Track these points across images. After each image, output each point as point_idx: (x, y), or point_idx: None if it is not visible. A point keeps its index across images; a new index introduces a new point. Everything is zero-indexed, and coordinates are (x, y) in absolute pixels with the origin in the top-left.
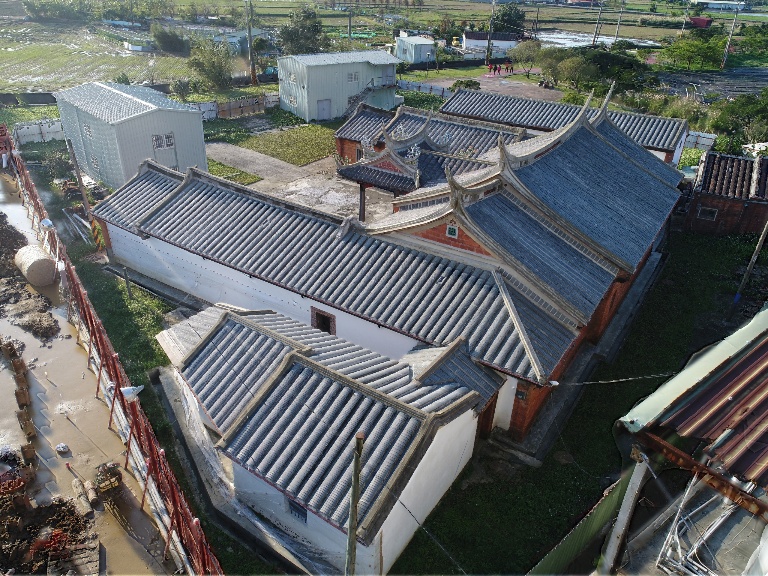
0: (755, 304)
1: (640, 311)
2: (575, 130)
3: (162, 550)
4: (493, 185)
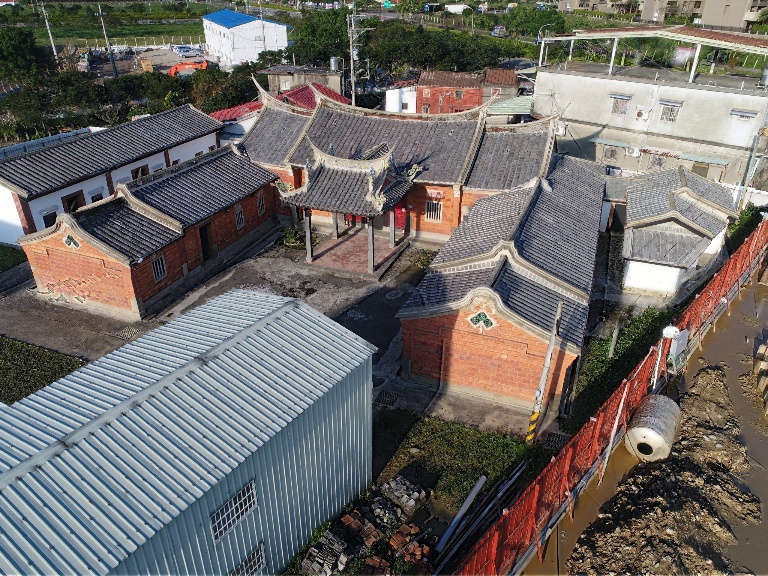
0: None
1: None
2: None
3: (766, 261)
4: None
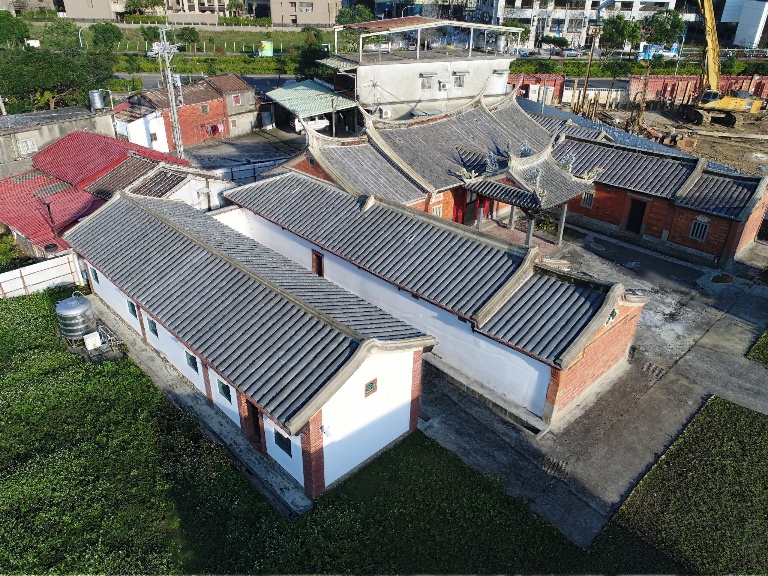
0: None
1: None
2: None
3: None
4: None
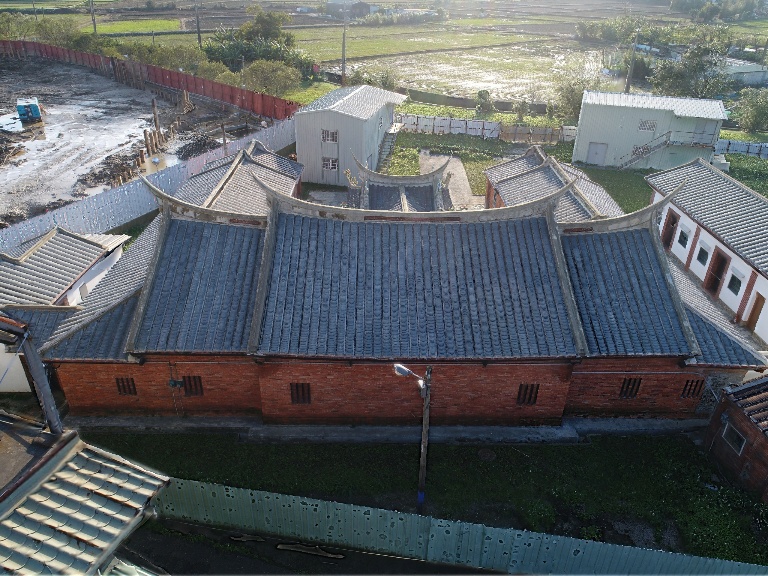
0: None
1: (376, 443)
2: (517, 217)
3: None
4: (251, 217)
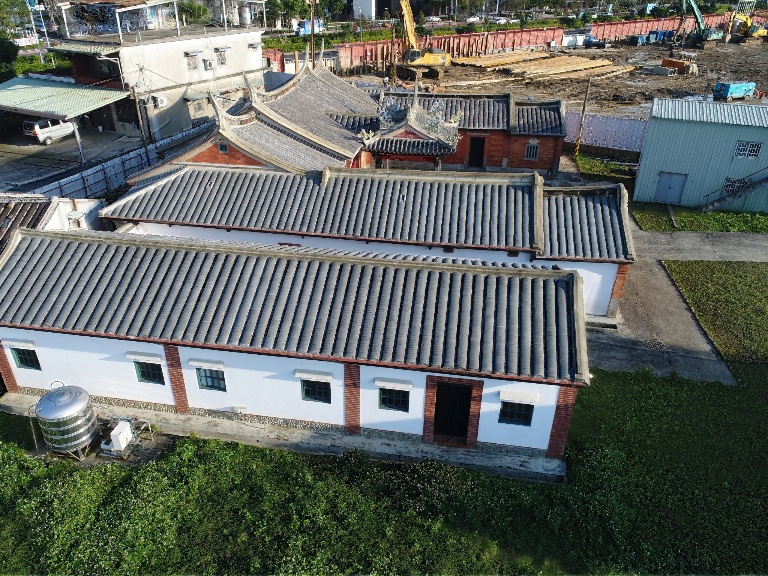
0: (119, 192)
1: None
2: None
3: None
4: None
